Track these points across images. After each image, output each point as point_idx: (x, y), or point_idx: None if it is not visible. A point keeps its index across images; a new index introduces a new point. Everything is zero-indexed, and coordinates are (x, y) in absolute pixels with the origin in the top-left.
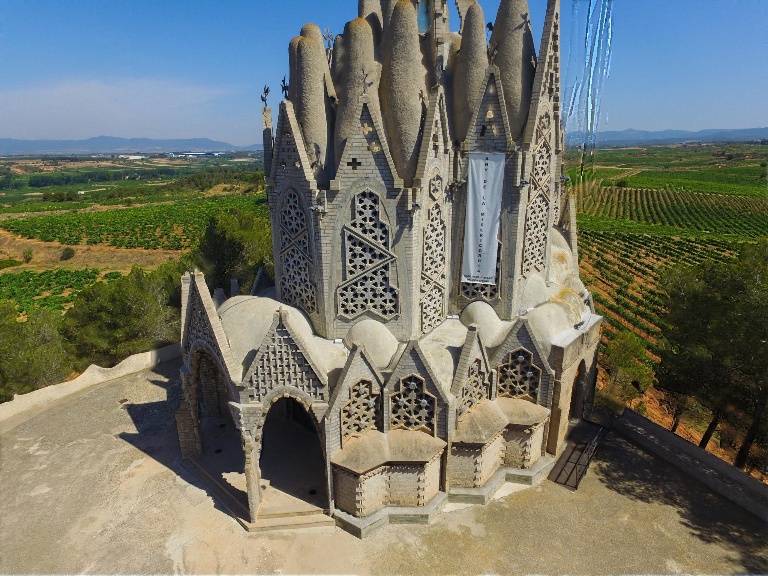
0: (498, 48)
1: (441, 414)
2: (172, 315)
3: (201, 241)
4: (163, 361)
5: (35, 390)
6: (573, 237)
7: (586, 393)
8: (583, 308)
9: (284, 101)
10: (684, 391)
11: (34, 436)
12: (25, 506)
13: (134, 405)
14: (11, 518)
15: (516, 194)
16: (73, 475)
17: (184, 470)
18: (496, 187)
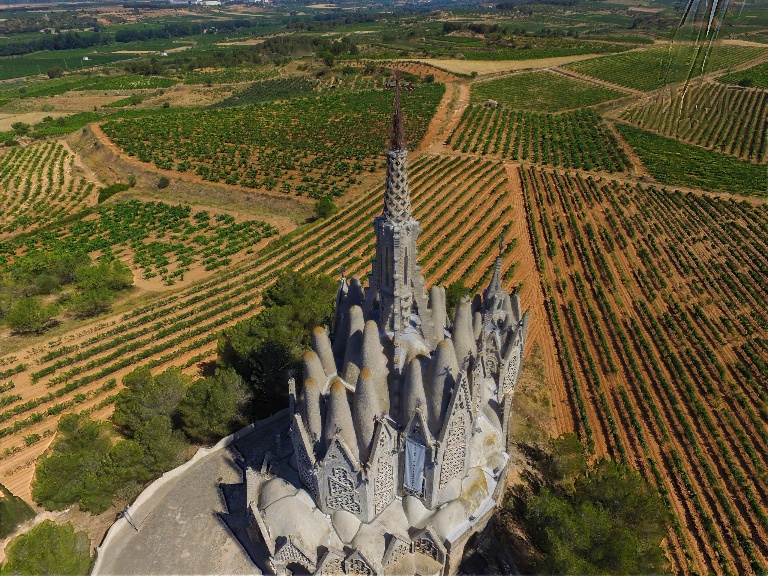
0: (431, 378)
1: (374, 574)
2: (246, 389)
3: (263, 349)
4: (241, 437)
5: (173, 469)
6: (505, 422)
7: (482, 537)
8: (485, 497)
9: (296, 417)
10: (541, 551)
11: (177, 506)
12: (180, 565)
13: (226, 485)
14: (175, 573)
15: (433, 463)
16: (199, 545)
17: (252, 552)
18: (421, 458)
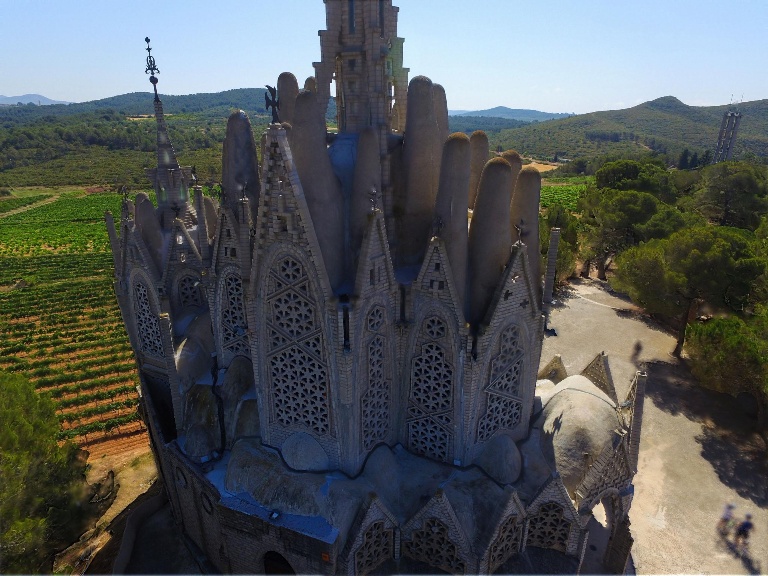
0: None
1: None
2: None
3: None
4: None
5: None
6: None
7: None
8: None
9: None
10: None
11: None
12: None
13: None
14: None
15: None
16: None
17: (627, 567)
18: None
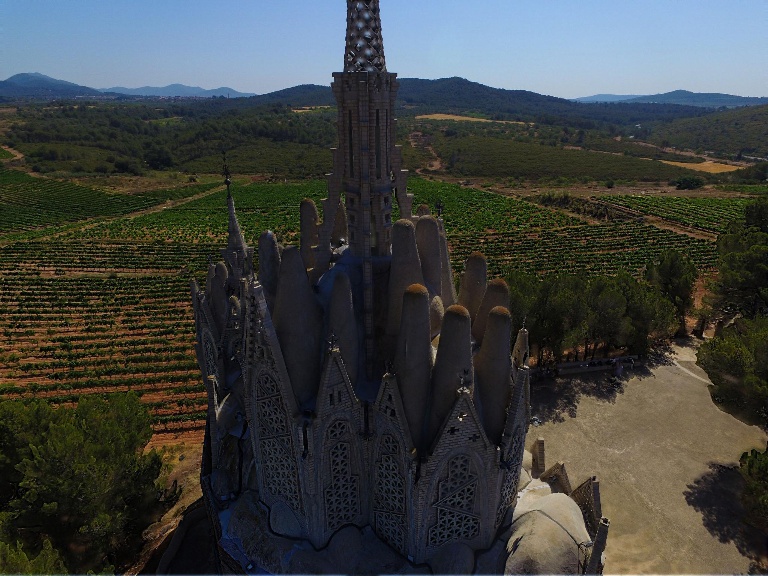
0: None
1: None
2: None
3: None
4: None
5: None
6: None
7: None
8: None
9: None
10: None
11: None
12: None
13: None
14: None
15: None
16: None
17: None
18: None
